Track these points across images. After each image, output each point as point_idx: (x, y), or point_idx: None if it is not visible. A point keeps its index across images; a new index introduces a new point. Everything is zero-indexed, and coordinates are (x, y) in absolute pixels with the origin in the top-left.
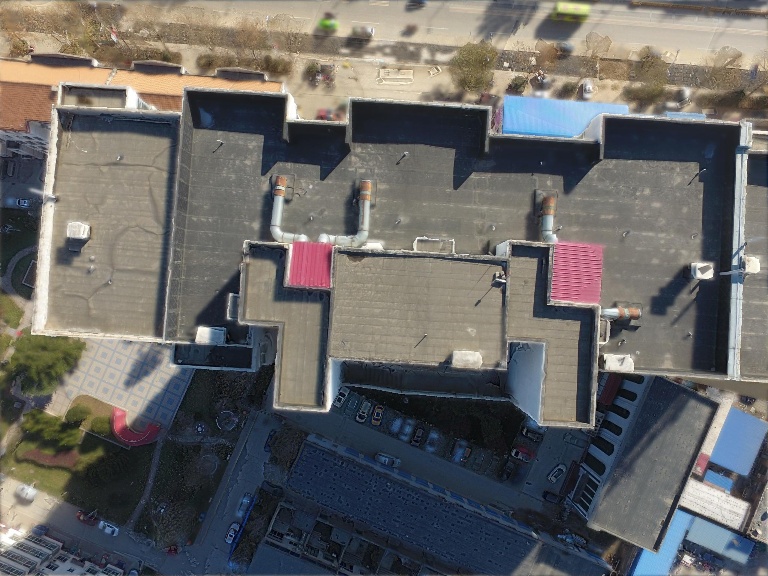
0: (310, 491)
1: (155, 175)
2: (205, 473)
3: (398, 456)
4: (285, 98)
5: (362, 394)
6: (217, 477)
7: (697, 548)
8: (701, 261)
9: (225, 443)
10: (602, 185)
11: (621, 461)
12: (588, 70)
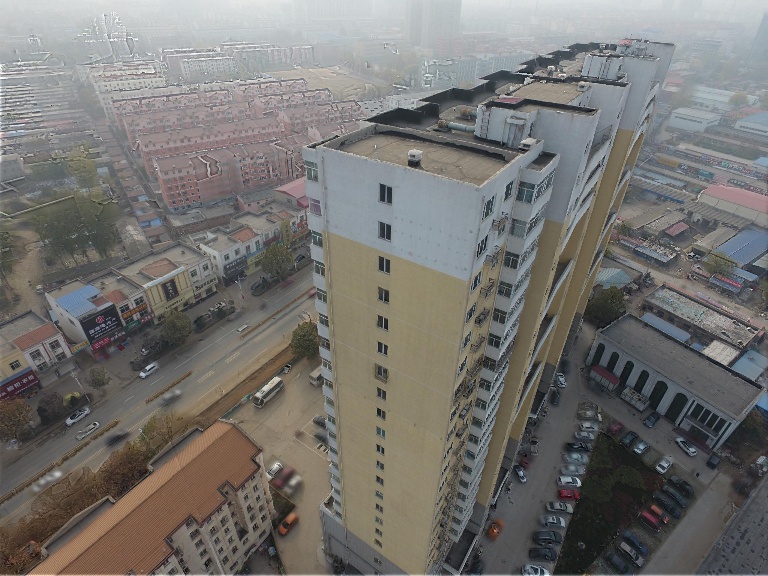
0: None
1: (399, 143)
2: None
3: None
4: (399, 108)
5: None
6: None
7: None
8: None
9: None
10: None
11: None
12: None
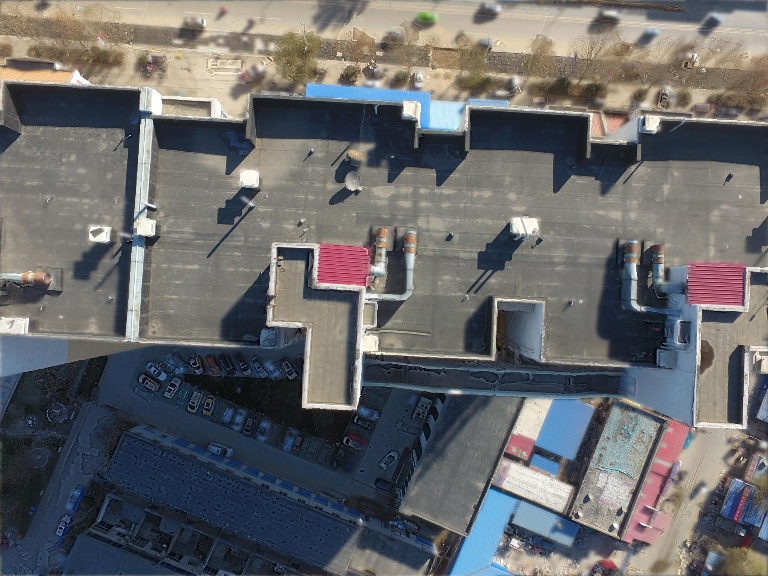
0: (130, 481)
1: None
2: (24, 465)
3: (231, 446)
4: None
5: (194, 384)
6: (49, 470)
7: (527, 532)
8: (123, 226)
9: (57, 436)
10: (29, 152)
11: (434, 446)
12: (421, 59)
